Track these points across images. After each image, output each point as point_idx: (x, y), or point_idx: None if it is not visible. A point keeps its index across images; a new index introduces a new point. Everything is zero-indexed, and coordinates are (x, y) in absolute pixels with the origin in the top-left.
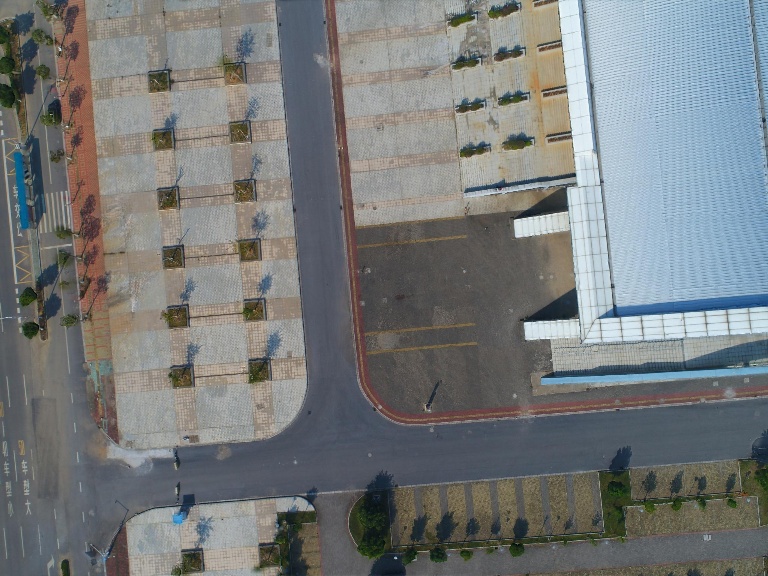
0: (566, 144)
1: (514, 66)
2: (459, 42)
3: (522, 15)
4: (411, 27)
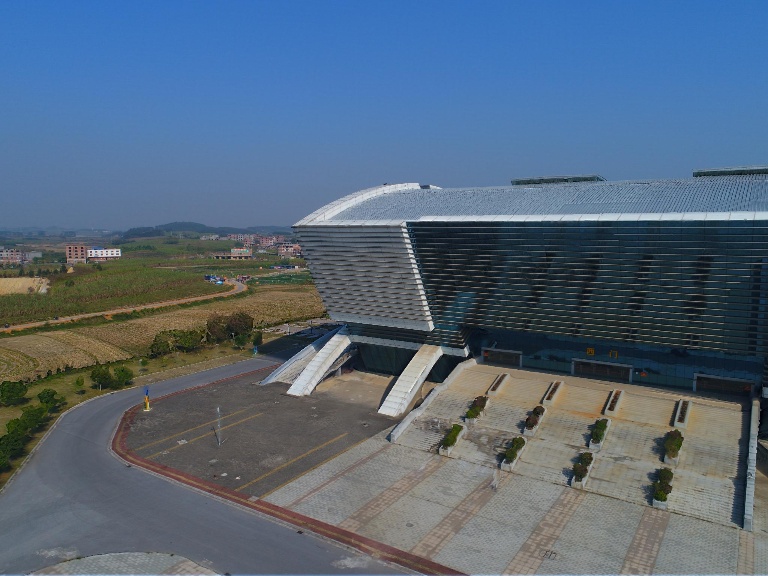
0: (692, 414)
1: (551, 421)
2: (476, 451)
3: (494, 401)
4: (412, 474)
